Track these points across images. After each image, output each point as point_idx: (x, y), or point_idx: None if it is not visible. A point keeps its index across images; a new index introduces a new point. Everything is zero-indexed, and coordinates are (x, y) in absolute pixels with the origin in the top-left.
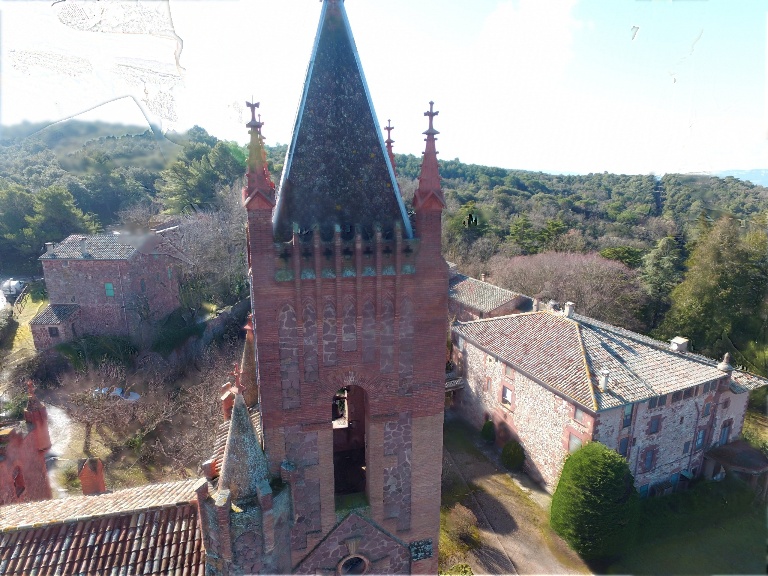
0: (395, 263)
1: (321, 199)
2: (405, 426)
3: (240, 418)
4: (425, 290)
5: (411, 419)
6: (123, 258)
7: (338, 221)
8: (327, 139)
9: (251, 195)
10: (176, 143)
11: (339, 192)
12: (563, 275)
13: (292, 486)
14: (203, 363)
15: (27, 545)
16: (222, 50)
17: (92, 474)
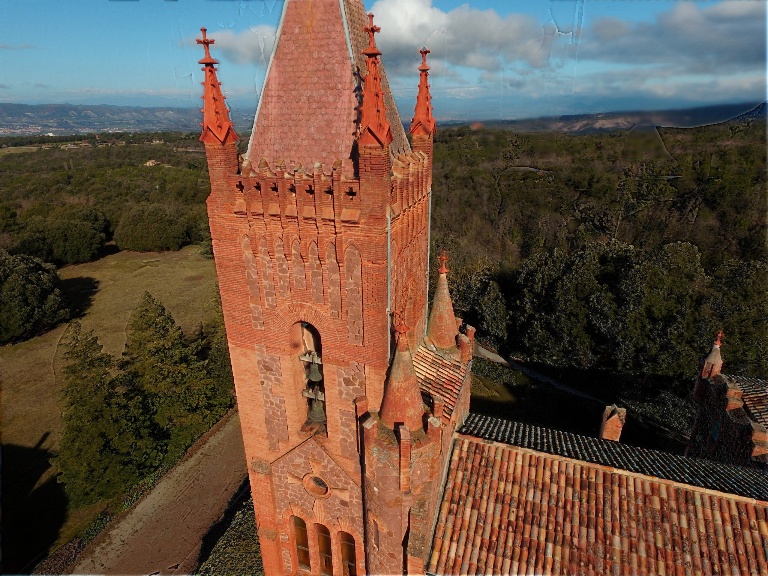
0: None
1: None
2: None
3: None
4: None
5: None
6: None
7: None
8: None
9: None
10: None
11: None
12: None
13: None
14: None
15: None
16: None
17: None
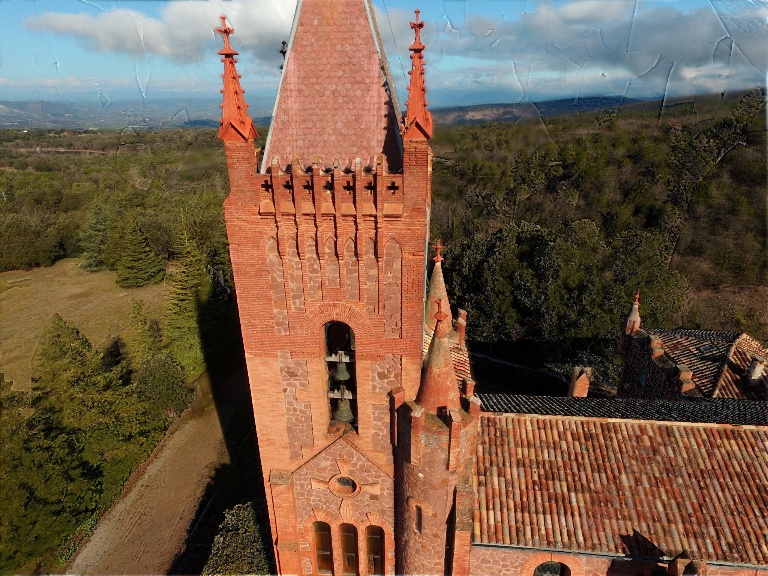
0: None
1: None
2: None
3: None
4: None
5: None
6: None
7: None
8: None
9: None
10: None
11: None
12: None
13: None
14: None
15: None
16: None
17: None
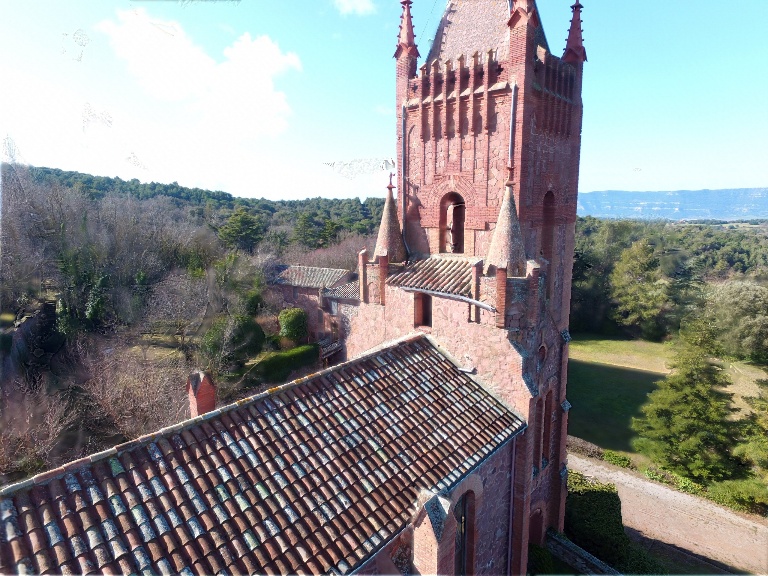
0: (571, 95)
1: None
2: (563, 231)
3: (515, 207)
4: (576, 121)
5: (566, 225)
6: None
7: None
8: None
9: (531, 11)
10: None
11: None
12: (372, 253)
13: None
14: (73, 361)
15: (306, 398)
16: None
17: (209, 390)
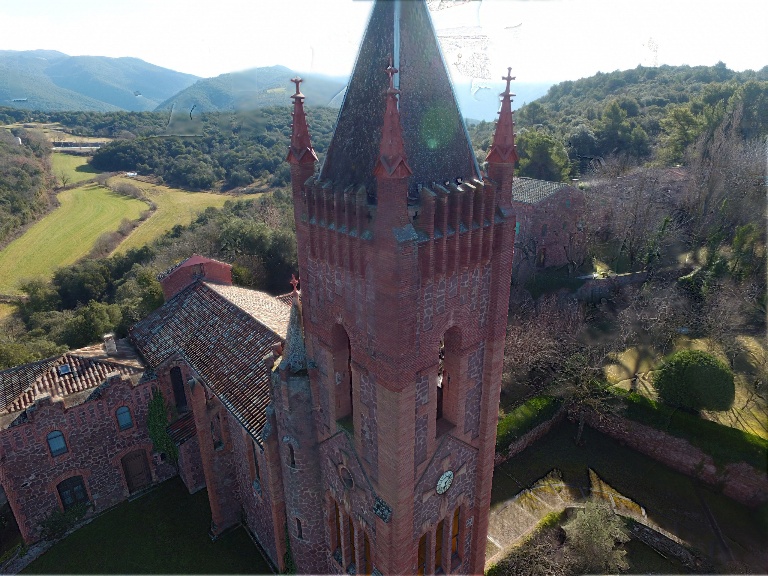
0: None
1: (346, 159)
2: (373, 386)
3: (292, 313)
4: (381, 261)
5: (376, 382)
6: (531, 202)
7: (350, 180)
8: (360, 103)
9: None
10: (490, 99)
11: (357, 153)
12: None
13: (312, 380)
14: (538, 311)
15: None
16: (505, 3)
17: None
